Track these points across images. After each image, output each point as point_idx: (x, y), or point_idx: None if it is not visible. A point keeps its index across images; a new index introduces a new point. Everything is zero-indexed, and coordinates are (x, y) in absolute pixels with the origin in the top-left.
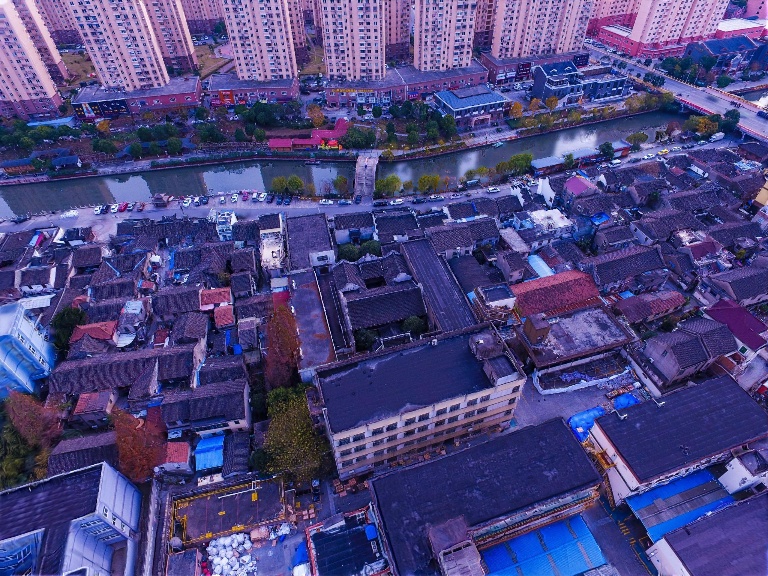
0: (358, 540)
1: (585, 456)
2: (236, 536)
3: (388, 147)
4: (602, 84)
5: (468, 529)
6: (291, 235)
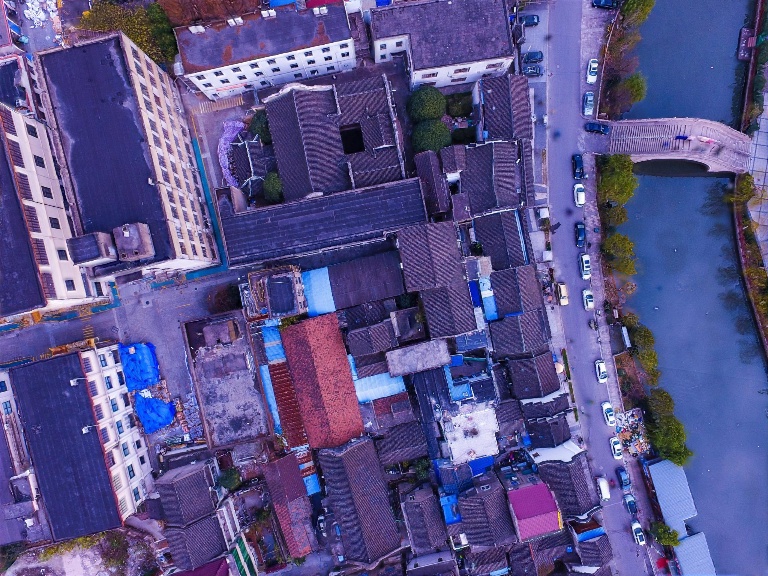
0: (8, 103)
1: (1, 314)
2: (54, 2)
3: None
4: None
5: None
6: (458, 3)
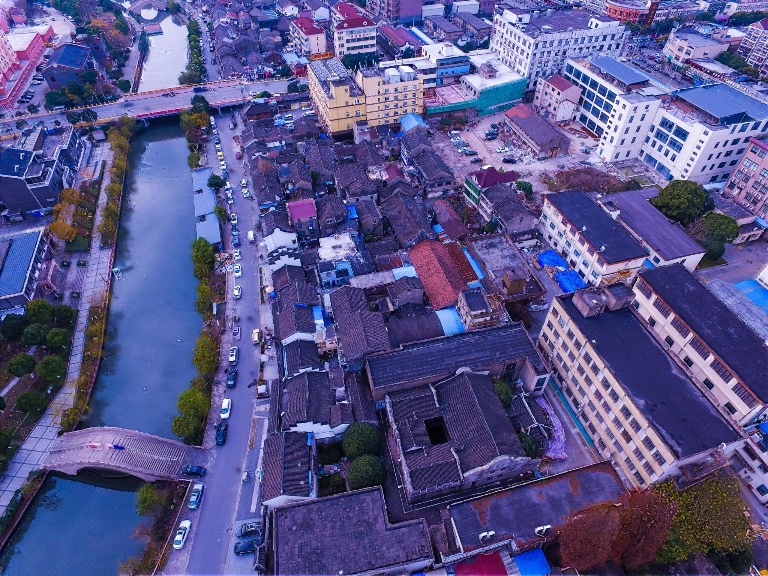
0: None
1: (665, 267)
2: None
3: (35, 417)
4: (68, 148)
5: (761, 339)
6: (332, 572)
